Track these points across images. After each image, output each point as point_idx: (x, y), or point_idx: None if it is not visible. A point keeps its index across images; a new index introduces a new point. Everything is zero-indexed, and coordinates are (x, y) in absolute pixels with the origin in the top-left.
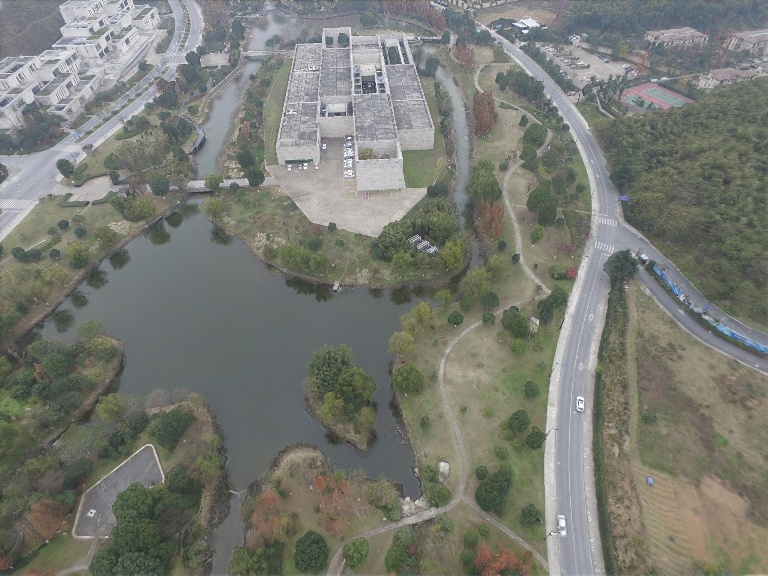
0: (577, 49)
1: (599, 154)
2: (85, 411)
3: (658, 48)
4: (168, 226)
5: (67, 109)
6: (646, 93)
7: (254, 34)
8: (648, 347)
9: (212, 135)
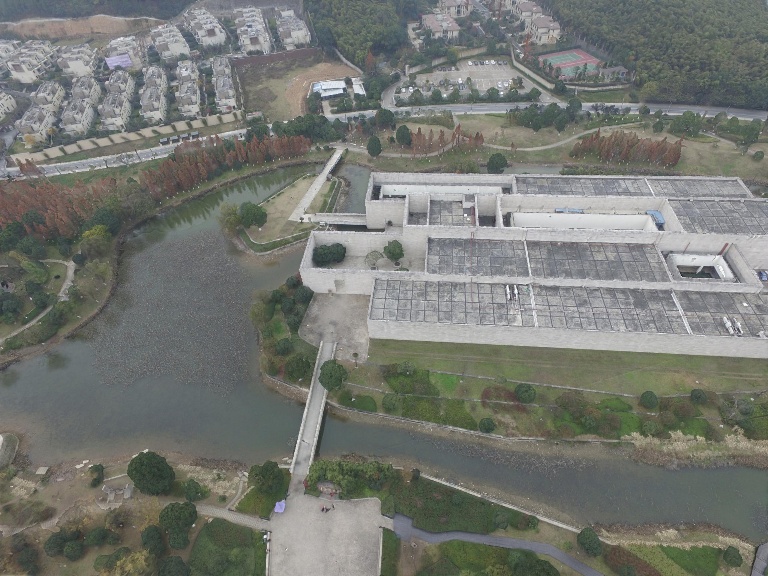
0: None
1: (686, 108)
2: None
3: (464, 37)
4: None
5: None
6: (555, 64)
7: (124, 448)
8: None
9: None
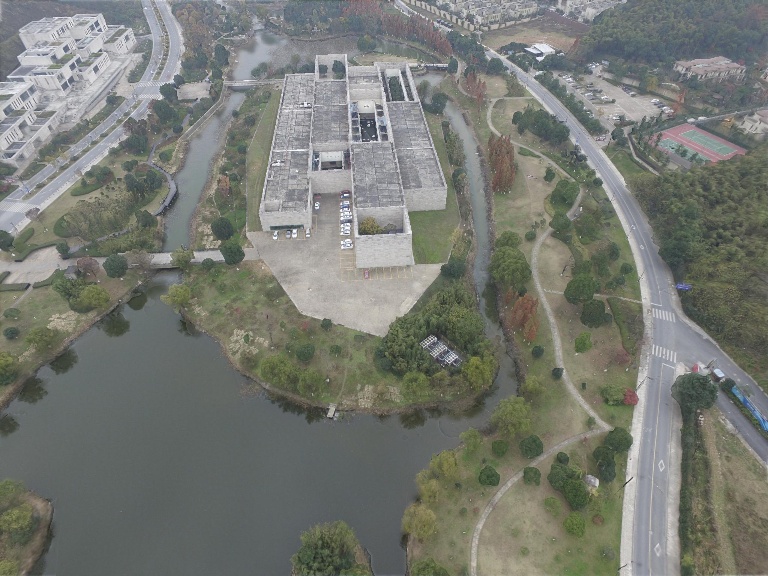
0: (598, 79)
1: (640, 217)
2: None
3: (691, 81)
4: (129, 308)
5: (17, 156)
6: (684, 137)
7: (240, 59)
8: (743, 518)
9: (186, 188)
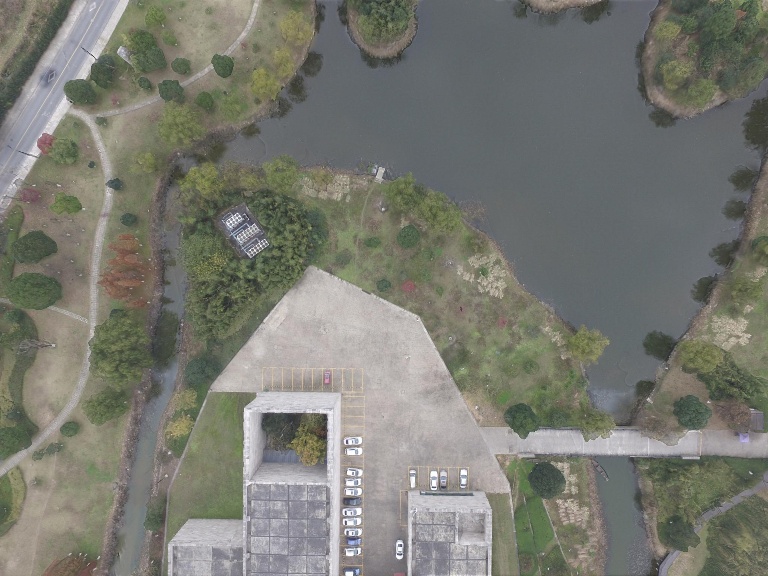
0: None
1: None
2: (663, 4)
3: None
4: None
5: None
6: None
7: None
8: (2, 20)
9: None
